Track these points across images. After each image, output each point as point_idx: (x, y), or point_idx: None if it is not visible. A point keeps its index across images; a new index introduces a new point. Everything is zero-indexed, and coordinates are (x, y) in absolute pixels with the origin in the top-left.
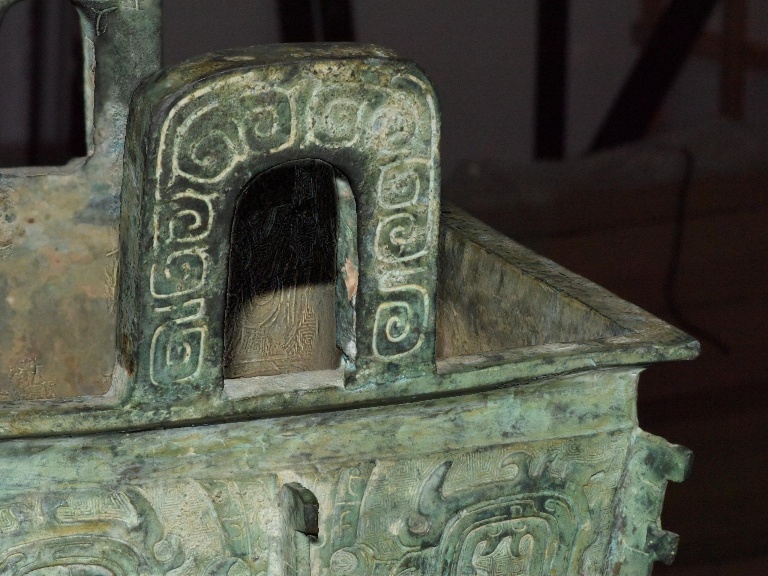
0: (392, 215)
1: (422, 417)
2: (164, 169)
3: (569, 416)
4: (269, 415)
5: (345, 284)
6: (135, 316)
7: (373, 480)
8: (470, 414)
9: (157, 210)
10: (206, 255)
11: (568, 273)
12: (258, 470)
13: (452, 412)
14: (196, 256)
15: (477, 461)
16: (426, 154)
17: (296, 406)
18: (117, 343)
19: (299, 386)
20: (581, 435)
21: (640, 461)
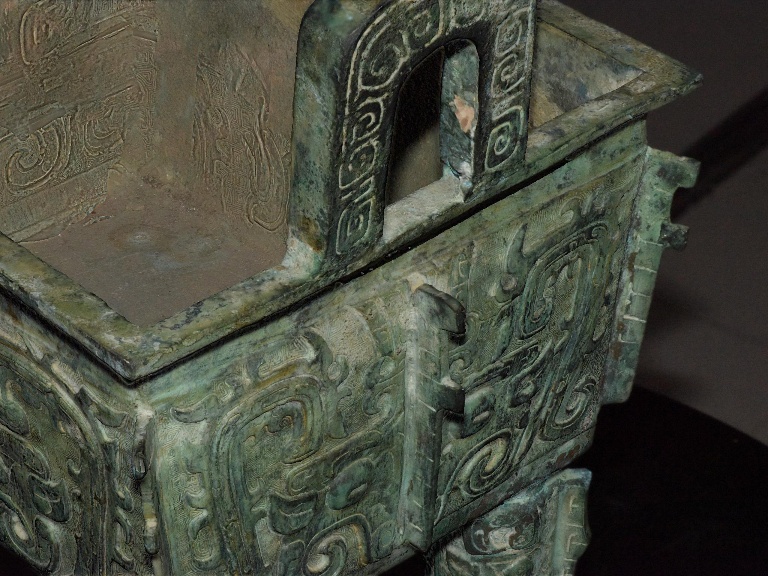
0: (503, 60)
1: None
2: (352, 89)
3: (603, 156)
4: (414, 244)
5: (456, 116)
6: (325, 208)
7: (474, 258)
8: None
9: (345, 122)
10: (377, 142)
11: None
12: (392, 280)
13: None
14: (370, 146)
15: (543, 216)
16: (527, 3)
17: (431, 229)
18: (291, 220)
19: (429, 211)
20: (614, 169)
21: (653, 174)
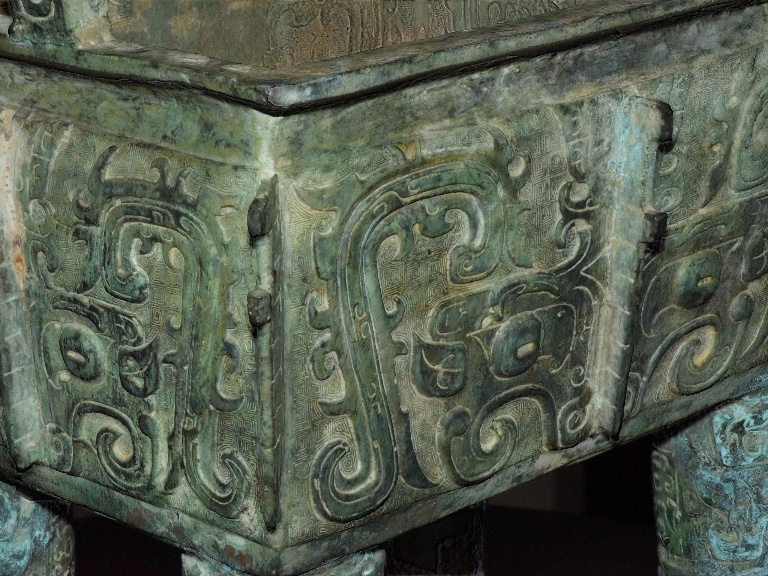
0: None
1: (119, 97)
2: None
3: (211, 137)
4: None
5: None
6: None
7: (65, 143)
8: (150, 107)
9: None
10: None
11: (514, 31)
12: None
13: (138, 100)
14: None
15: (137, 155)
16: None
17: None
18: None
19: None
20: (212, 160)
21: None
